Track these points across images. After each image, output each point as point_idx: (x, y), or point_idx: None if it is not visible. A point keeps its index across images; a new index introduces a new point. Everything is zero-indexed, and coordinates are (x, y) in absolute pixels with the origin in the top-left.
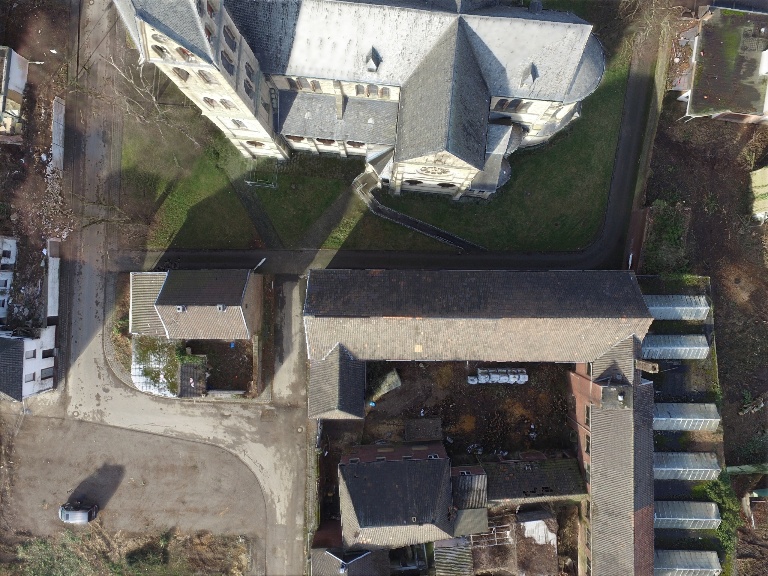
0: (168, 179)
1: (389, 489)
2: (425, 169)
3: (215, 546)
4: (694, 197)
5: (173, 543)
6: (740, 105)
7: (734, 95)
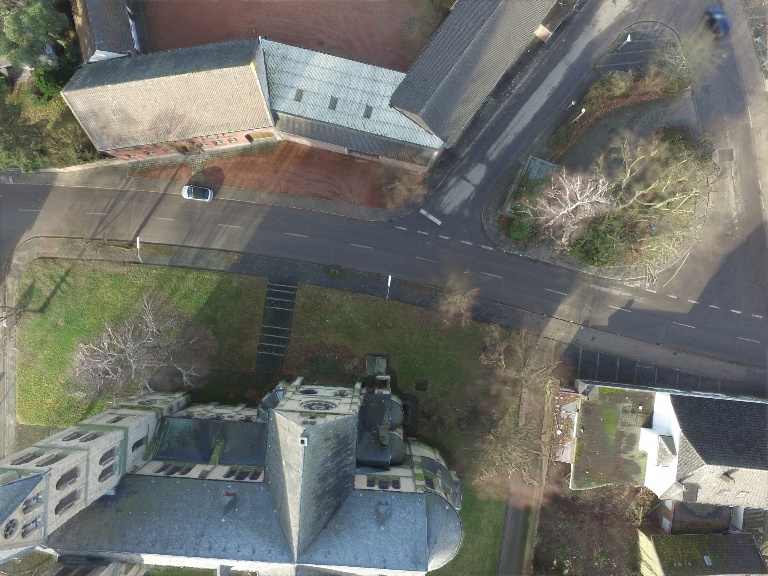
0: None
1: None
2: None
3: None
4: (584, 552)
5: None
6: (622, 479)
7: (615, 469)
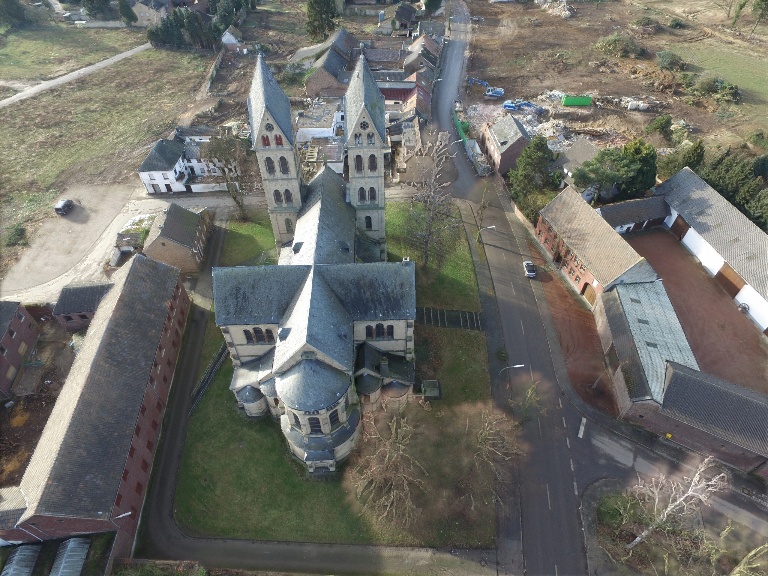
0: None
1: None
2: None
3: (4, 267)
4: None
5: (19, 248)
6: None
7: None
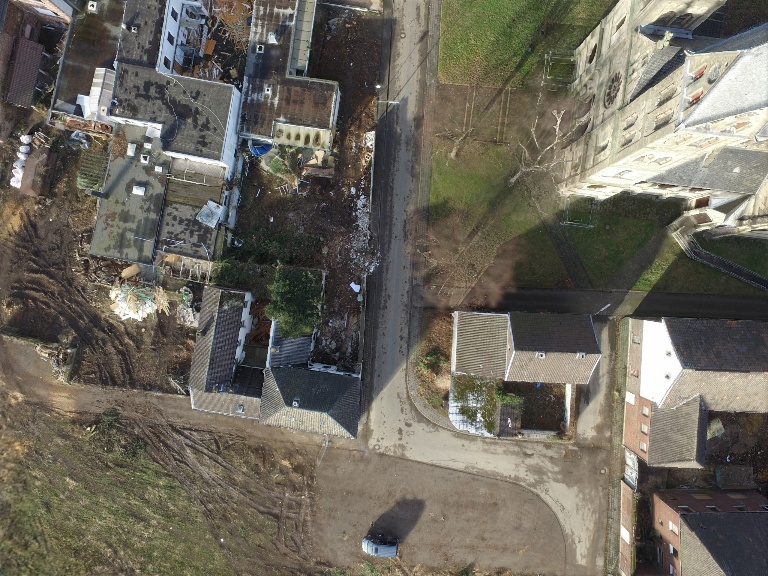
0: (479, 216)
1: (744, 542)
2: None
3: None
4: None
5: None
6: None
7: None
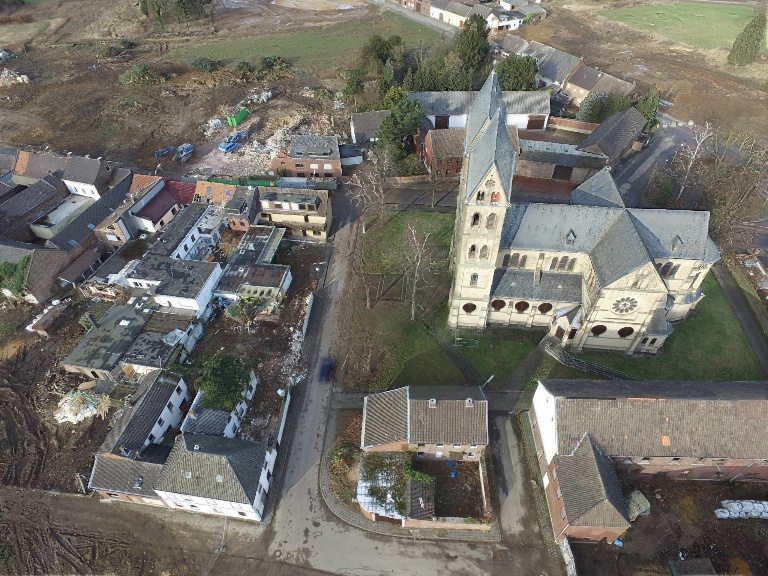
0: (389, 342)
1: None
2: (616, 306)
3: None
4: None
5: None
6: None
7: None
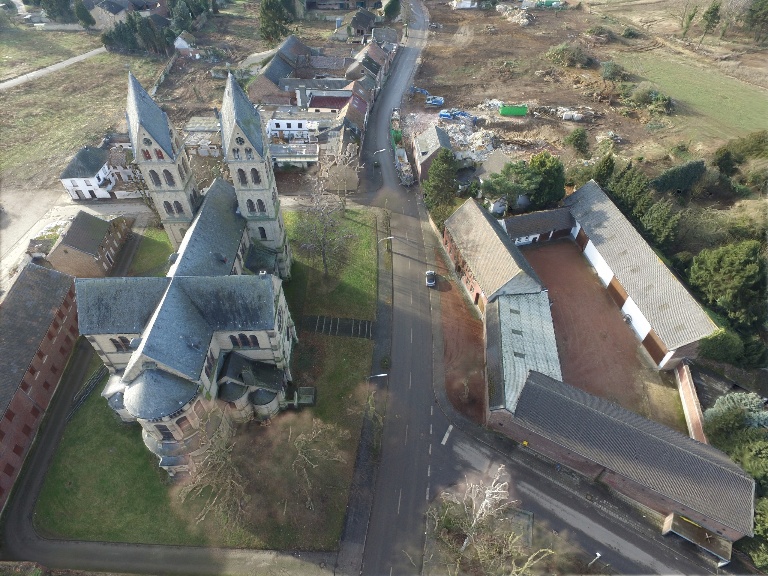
0: None
1: None
2: None
3: None
4: None
5: None
6: None
7: None
